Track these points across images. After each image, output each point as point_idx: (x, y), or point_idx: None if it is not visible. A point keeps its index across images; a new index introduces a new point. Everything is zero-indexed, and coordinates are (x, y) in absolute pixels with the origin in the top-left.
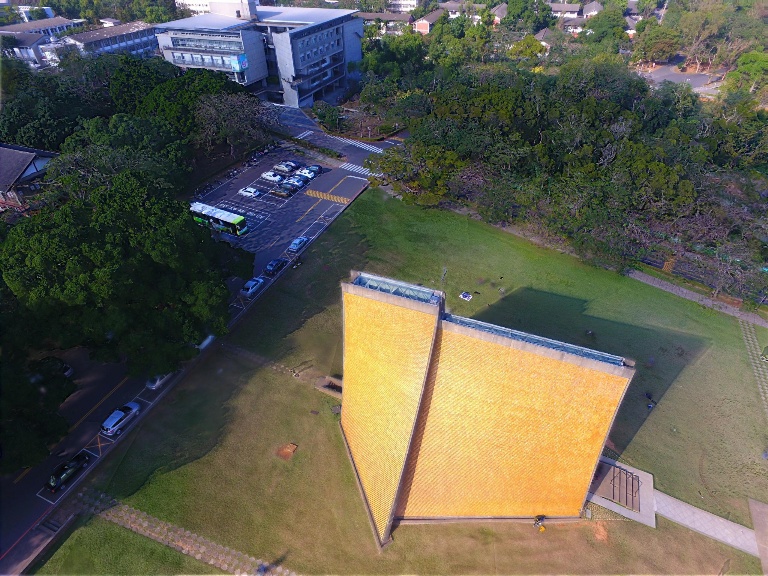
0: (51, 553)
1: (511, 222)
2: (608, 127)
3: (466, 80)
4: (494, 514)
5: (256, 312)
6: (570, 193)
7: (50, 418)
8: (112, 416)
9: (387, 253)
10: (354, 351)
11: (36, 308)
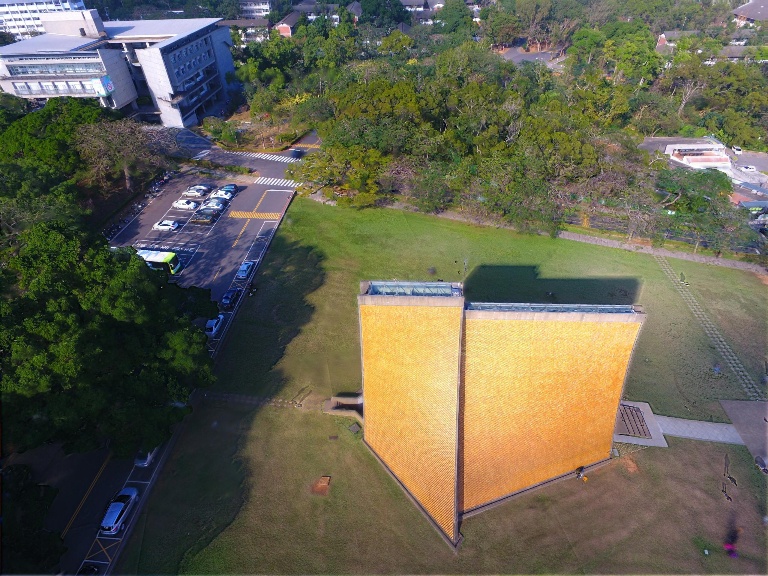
0: None
1: (443, 208)
2: (498, 107)
3: (350, 79)
4: (542, 480)
5: (229, 351)
6: (496, 171)
7: (39, 538)
8: (110, 511)
9: (340, 260)
10: (375, 363)
11: None
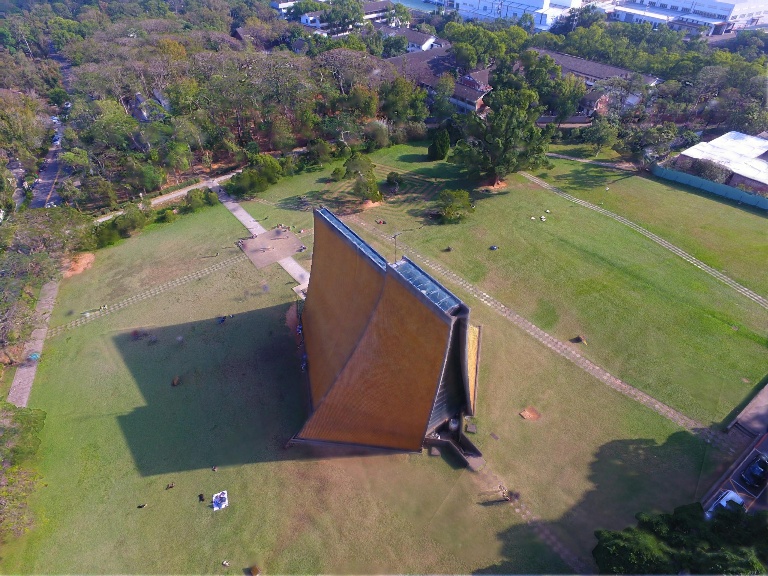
0: (733, 414)
1: None
2: None
3: None
4: None
5: None
6: None
7: None
8: None
9: None
10: None
11: None
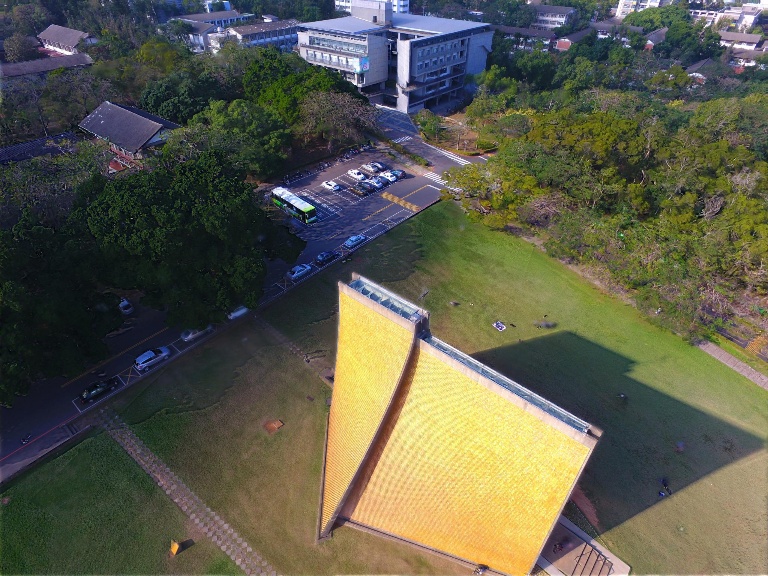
0: (65, 450)
1: (580, 261)
2: None
3: (587, 105)
4: (437, 547)
5: (294, 295)
6: (646, 241)
7: (95, 342)
8: (145, 354)
9: (437, 266)
10: (344, 349)
11: (106, 251)
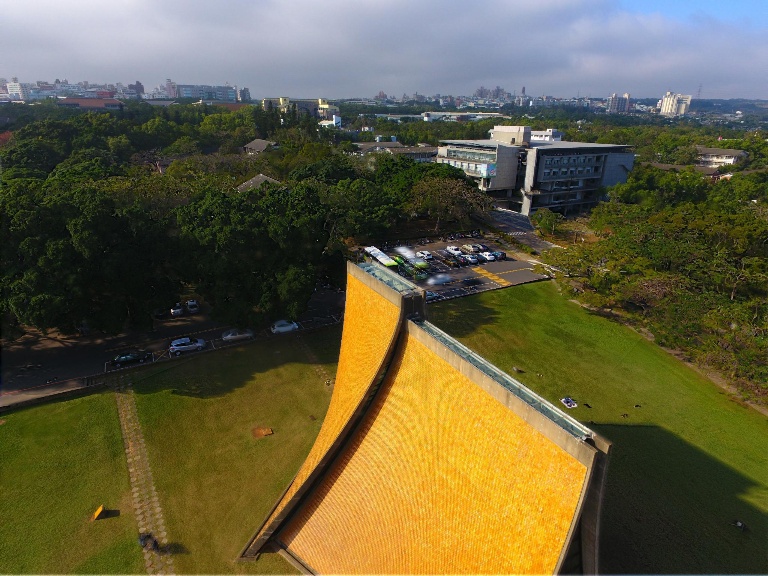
0: (73, 398)
1: None
2: None
3: None
4: None
5: None
6: None
7: (143, 313)
8: (182, 339)
9: (510, 334)
10: (344, 346)
11: (182, 238)
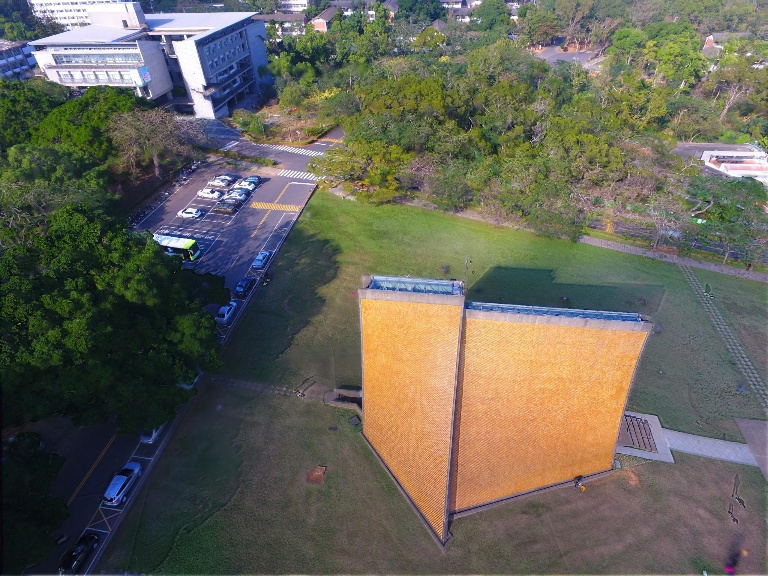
0: None
1: (463, 207)
2: (527, 107)
3: (380, 75)
4: (538, 486)
5: (238, 338)
6: (518, 172)
7: (44, 502)
8: (113, 483)
9: (354, 255)
10: (375, 357)
11: (1, 380)
